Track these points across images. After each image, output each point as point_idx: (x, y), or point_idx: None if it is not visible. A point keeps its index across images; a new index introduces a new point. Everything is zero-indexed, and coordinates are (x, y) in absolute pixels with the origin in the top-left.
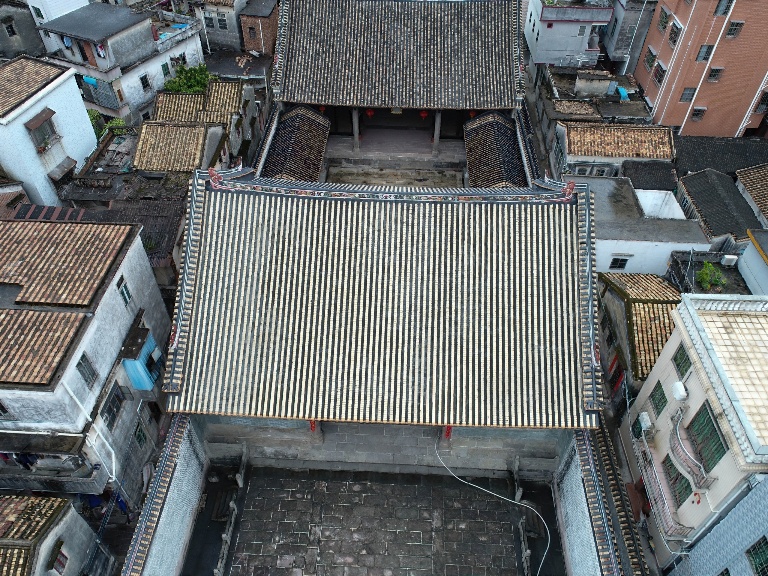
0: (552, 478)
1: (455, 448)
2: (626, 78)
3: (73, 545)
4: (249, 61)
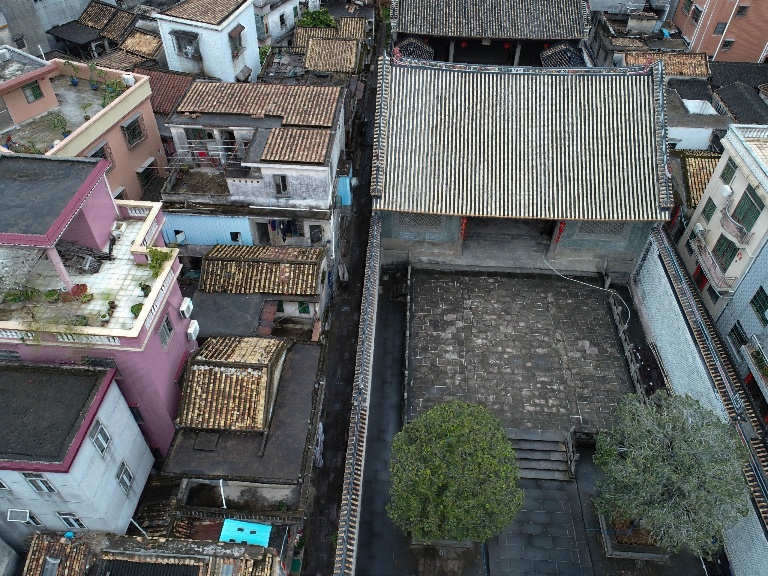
0: (629, 279)
1: (558, 259)
2: (667, 23)
3: None
4: (356, 9)
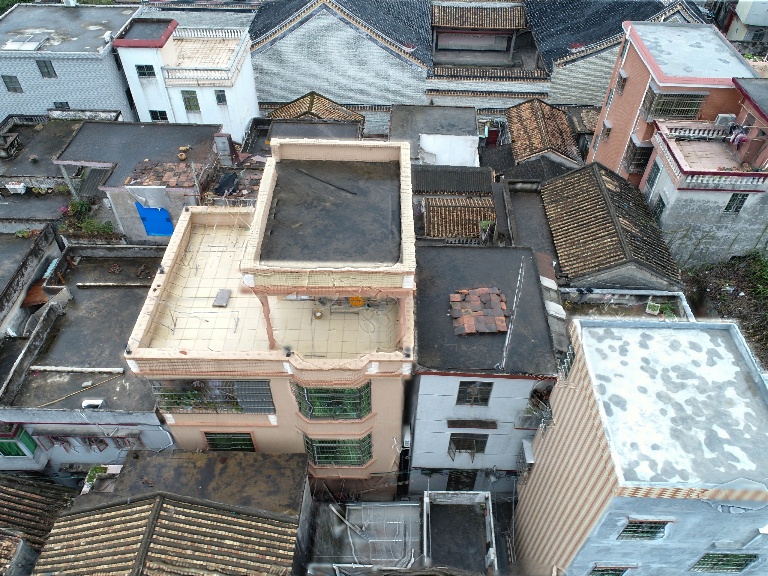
0: None
1: None
2: None
3: None
4: None
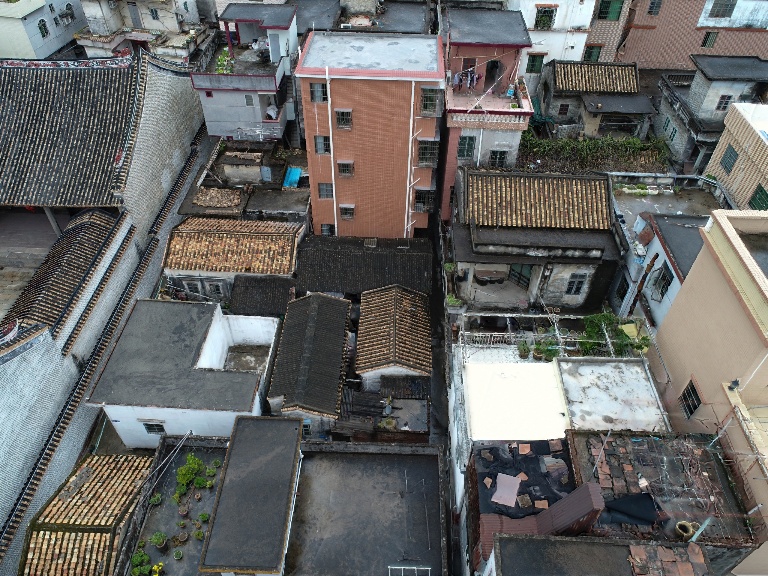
0: None
1: None
2: None
3: None
4: None
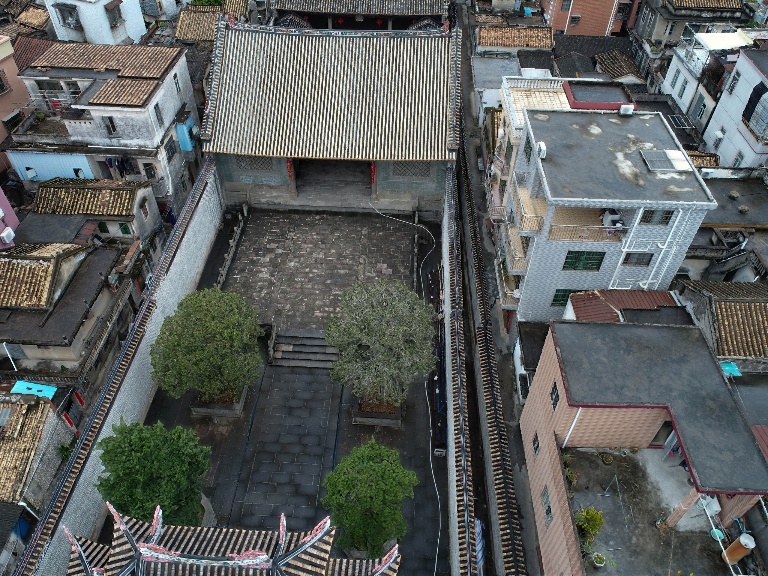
0: (441, 217)
1: (381, 200)
2: (534, 3)
3: (151, 209)
4: None
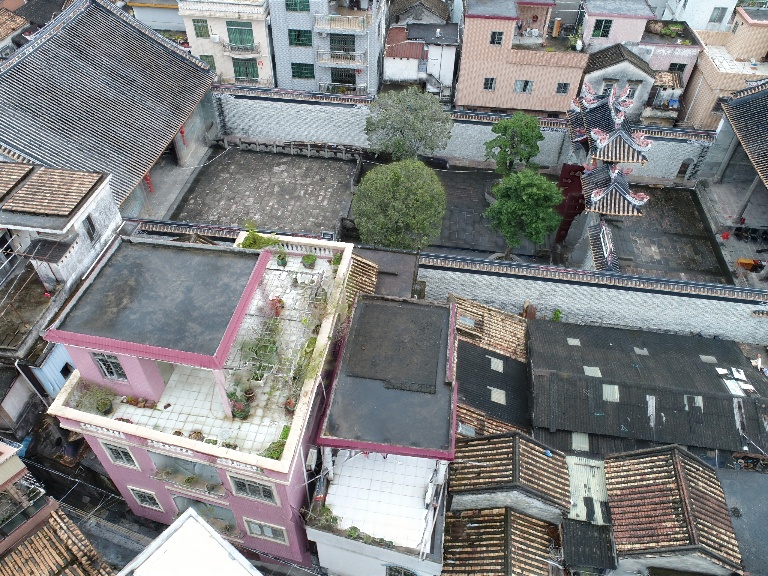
0: None
1: (186, 162)
2: None
3: None
4: None
